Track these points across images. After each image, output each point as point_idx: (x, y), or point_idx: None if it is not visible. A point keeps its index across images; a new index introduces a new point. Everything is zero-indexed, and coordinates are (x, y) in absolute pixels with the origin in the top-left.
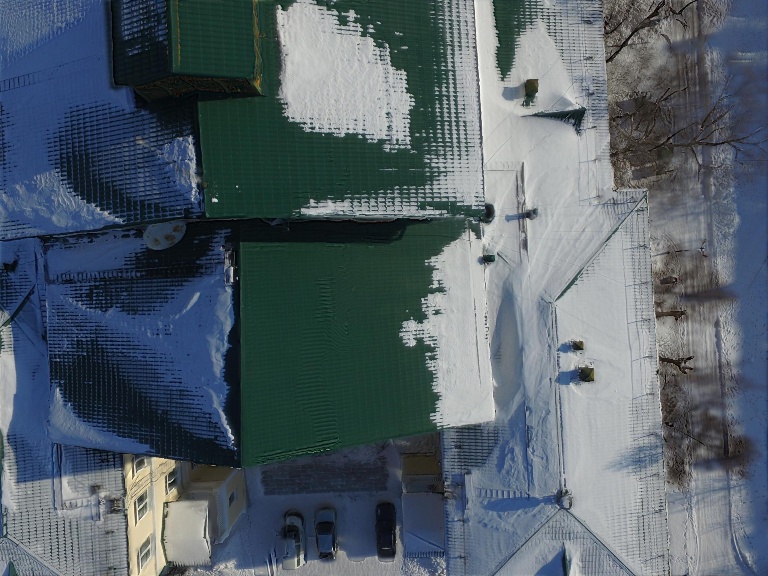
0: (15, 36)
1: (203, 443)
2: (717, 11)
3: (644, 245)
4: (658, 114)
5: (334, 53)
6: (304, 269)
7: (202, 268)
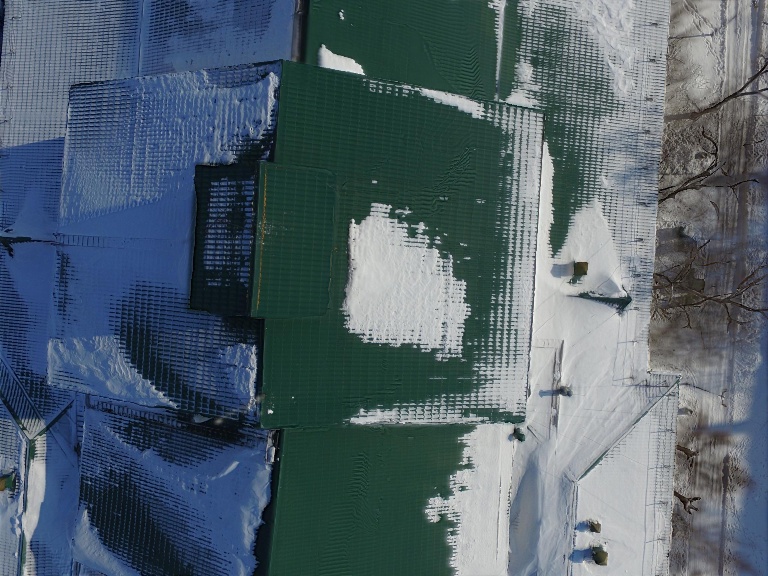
0: (89, 195)
1: None
2: (765, 151)
3: (671, 429)
4: (694, 249)
5: (400, 265)
6: (342, 445)
7: (244, 438)
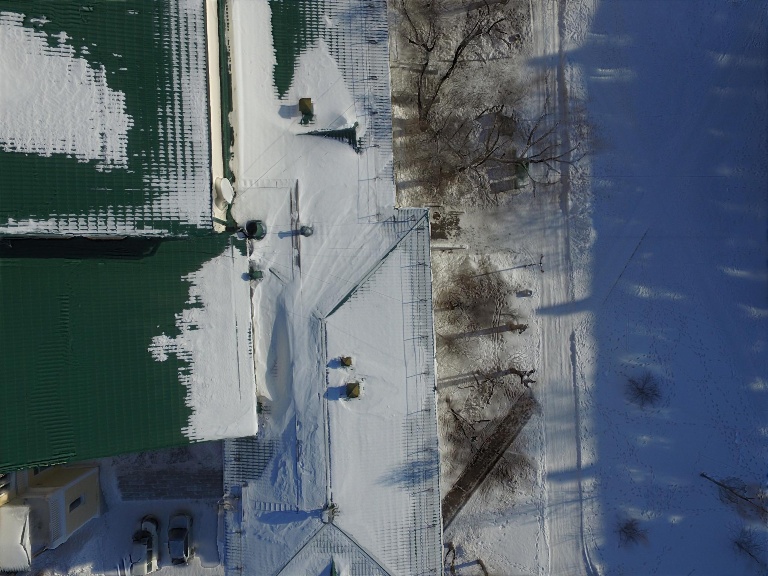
0: None
1: None
2: (578, 27)
3: (424, 263)
4: (514, 129)
5: (40, 74)
6: (44, 284)
7: None
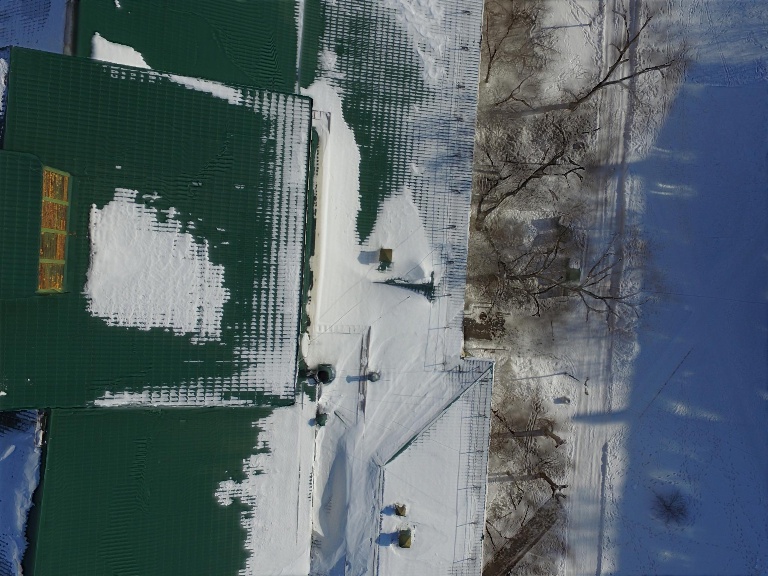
0: None
1: None
2: (643, 140)
3: (484, 415)
4: (569, 239)
5: (147, 250)
6: (123, 429)
7: (20, 422)
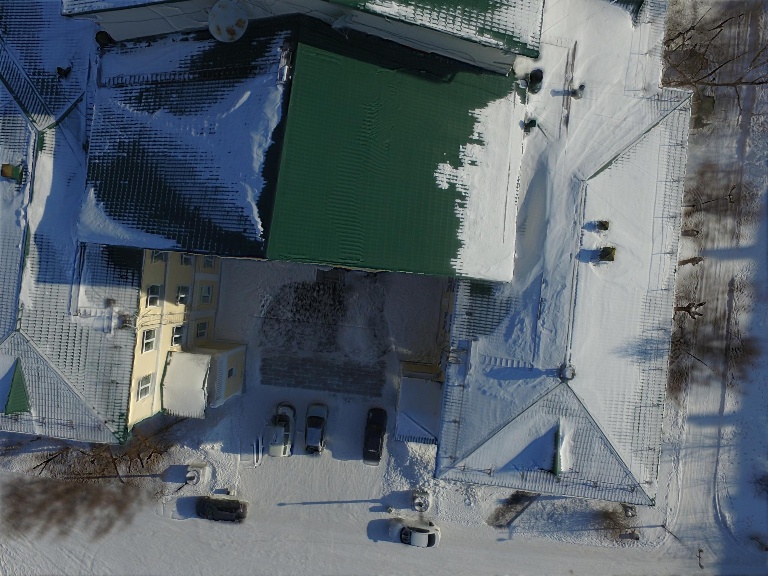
0: None
1: (231, 236)
2: None
3: (681, 145)
4: (705, 66)
5: None
6: (353, 90)
7: (256, 69)
